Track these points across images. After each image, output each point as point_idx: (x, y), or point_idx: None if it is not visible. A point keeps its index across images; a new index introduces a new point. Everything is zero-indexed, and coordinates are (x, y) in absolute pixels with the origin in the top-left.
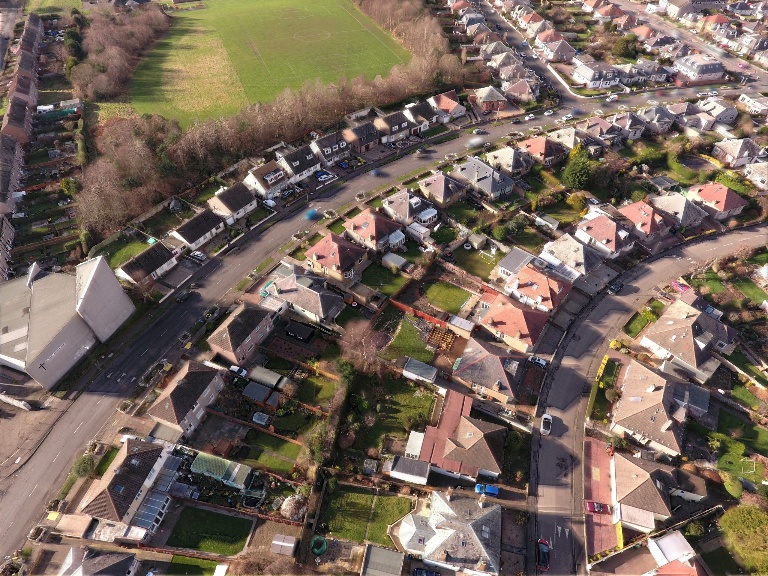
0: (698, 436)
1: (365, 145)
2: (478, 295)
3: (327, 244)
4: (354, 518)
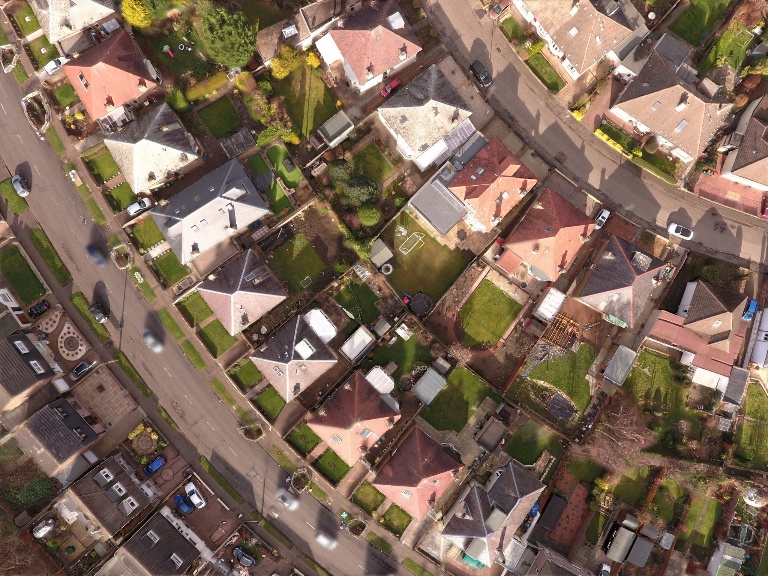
0: (706, 72)
1: (89, 427)
2: (488, 271)
3: (417, 493)
4: (764, 438)
